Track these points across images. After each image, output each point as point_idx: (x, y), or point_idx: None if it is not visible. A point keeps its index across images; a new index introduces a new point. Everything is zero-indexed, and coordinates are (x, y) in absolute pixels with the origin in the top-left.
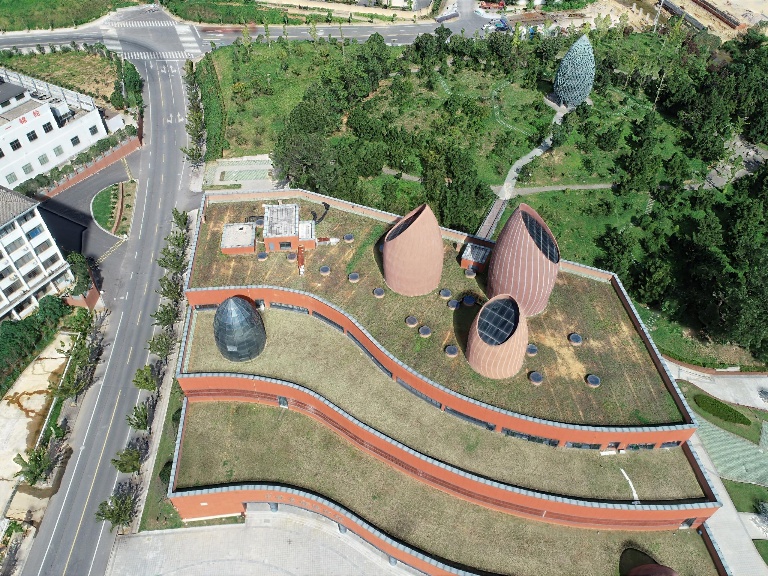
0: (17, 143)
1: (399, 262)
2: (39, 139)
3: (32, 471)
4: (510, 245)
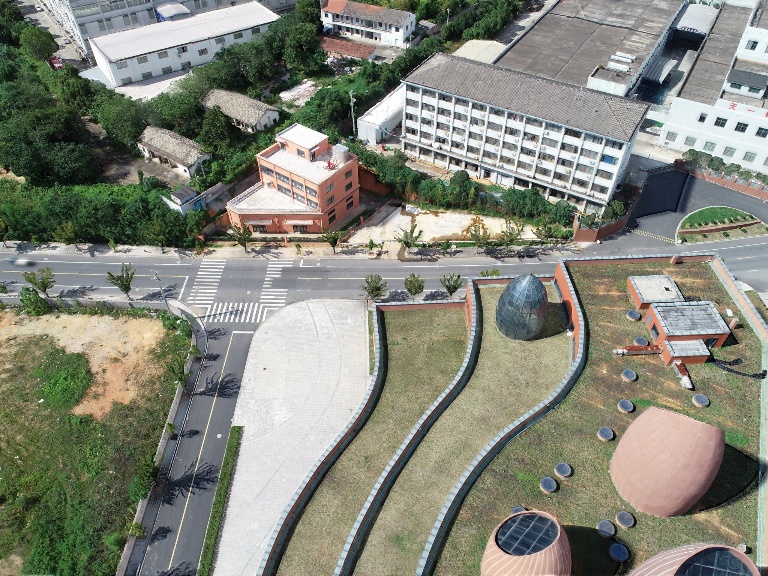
0: (745, 127)
1: (630, 428)
2: (765, 140)
3: (408, 238)
4: (667, 552)
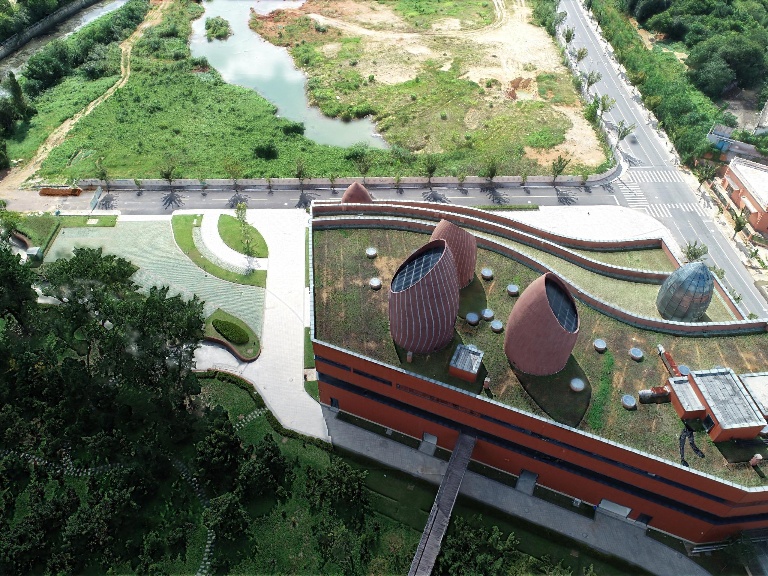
0: None
1: None
2: None
3: None
4: None
